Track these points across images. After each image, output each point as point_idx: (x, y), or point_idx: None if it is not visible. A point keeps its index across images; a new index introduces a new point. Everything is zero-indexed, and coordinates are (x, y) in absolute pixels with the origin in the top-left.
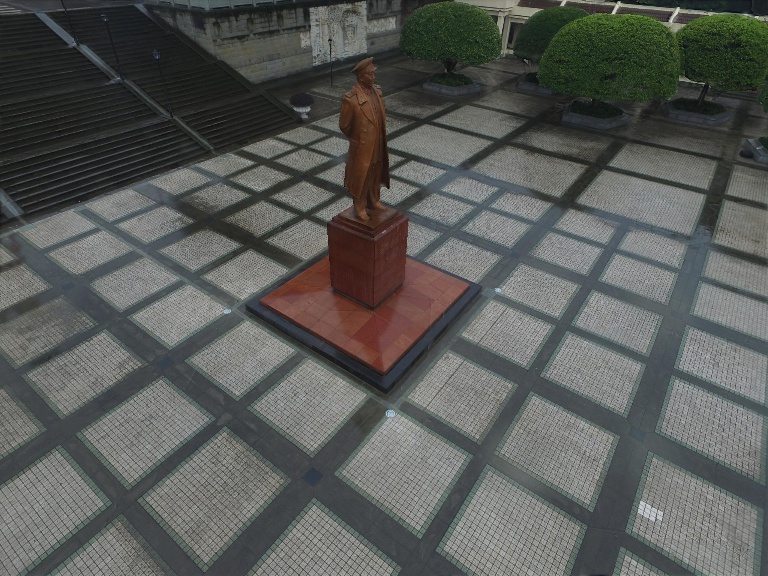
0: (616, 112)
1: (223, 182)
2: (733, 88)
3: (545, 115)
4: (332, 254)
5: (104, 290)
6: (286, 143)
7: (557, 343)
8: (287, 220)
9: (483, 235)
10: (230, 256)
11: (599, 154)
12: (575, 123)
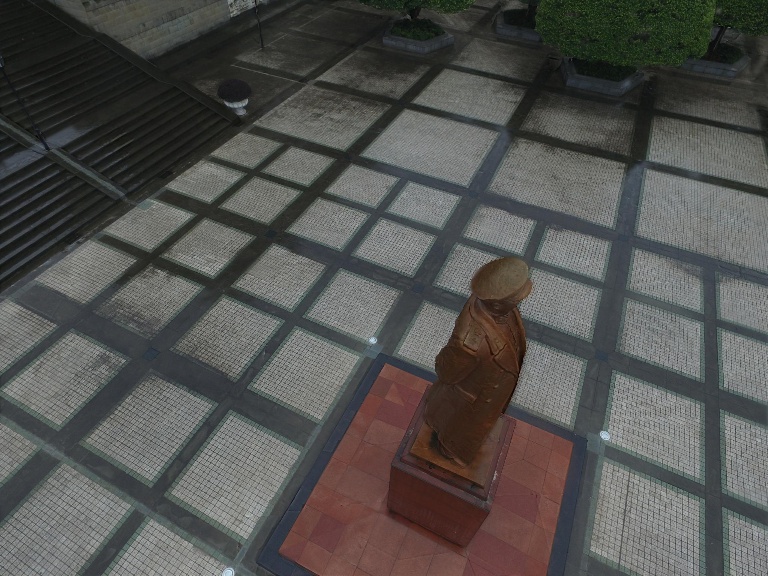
0: (630, 70)
1: (154, 263)
2: (765, 33)
3: (543, 77)
4: (396, 489)
5: (5, 565)
6: (228, 168)
7: (720, 539)
8: (270, 334)
9: (547, 320)
10: (202, 434)
11: (630, 141)
12: (583, 88)
